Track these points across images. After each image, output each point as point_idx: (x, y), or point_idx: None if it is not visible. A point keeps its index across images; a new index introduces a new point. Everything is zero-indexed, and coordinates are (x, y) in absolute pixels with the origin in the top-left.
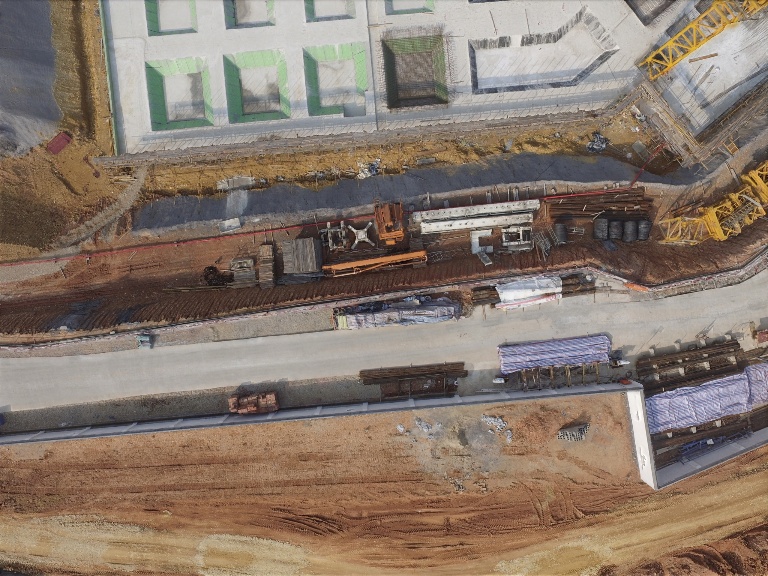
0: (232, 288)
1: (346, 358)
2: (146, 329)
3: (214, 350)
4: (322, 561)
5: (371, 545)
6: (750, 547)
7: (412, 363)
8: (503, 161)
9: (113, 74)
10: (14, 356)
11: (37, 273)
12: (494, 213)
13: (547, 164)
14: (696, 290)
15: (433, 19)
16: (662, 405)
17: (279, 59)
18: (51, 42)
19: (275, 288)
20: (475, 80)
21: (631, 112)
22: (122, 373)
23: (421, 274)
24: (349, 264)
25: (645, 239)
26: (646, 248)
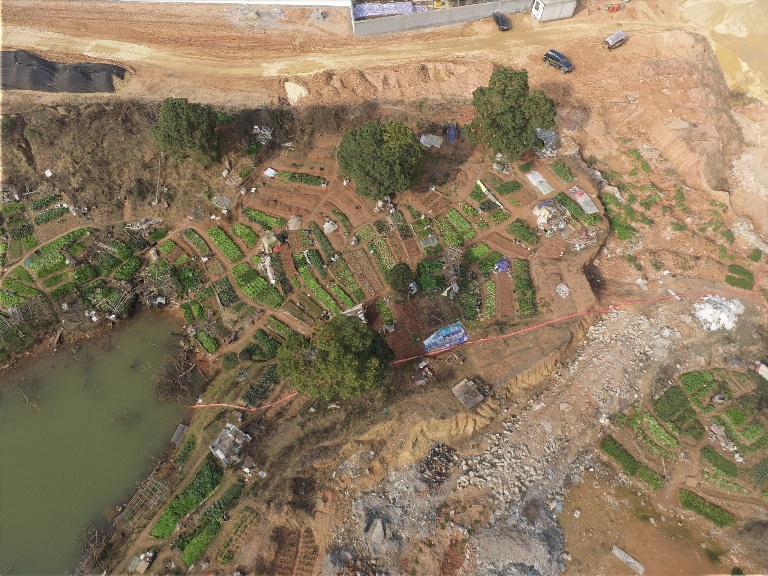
0: None
1: None
2: None
3: None
4: (159, 55)
5: None
6: None
7: None
8: None
9: None
10: None
11: None
12: None
13: None
14: None
15: None
16: (366, 8)
17: None
18: None
19: None
20: None
21: None
22: None
23: None
24: None
25: None
26: None
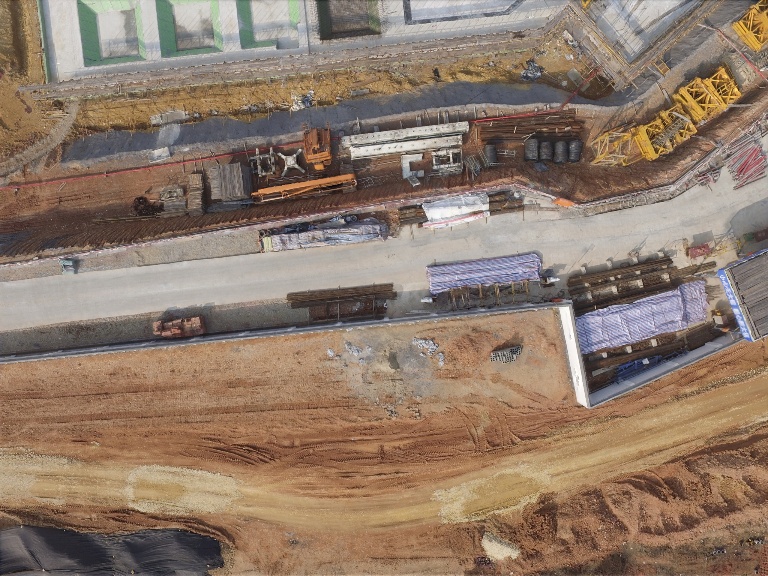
0: (162, 218)
1: (273, 281)
2: (70, 254)
3: (139, 275)
4: (254, 492)
5: (304, 474)
6: (691, 470)
7: (340, 285)
8: (436, 89)
9: (45, 11)
10: None
11: None
12: (424, 136)
13: (480, 91)
14: (627, 207)
15: None
16: (595, 324)
17: None
18: None
19: (204, 215)
20: (408, 11)
21: (564, 38)
22: (46, 299)
23: (349, 197)
24: (276, 188)
25: (577, 160)
26: (578, 169)
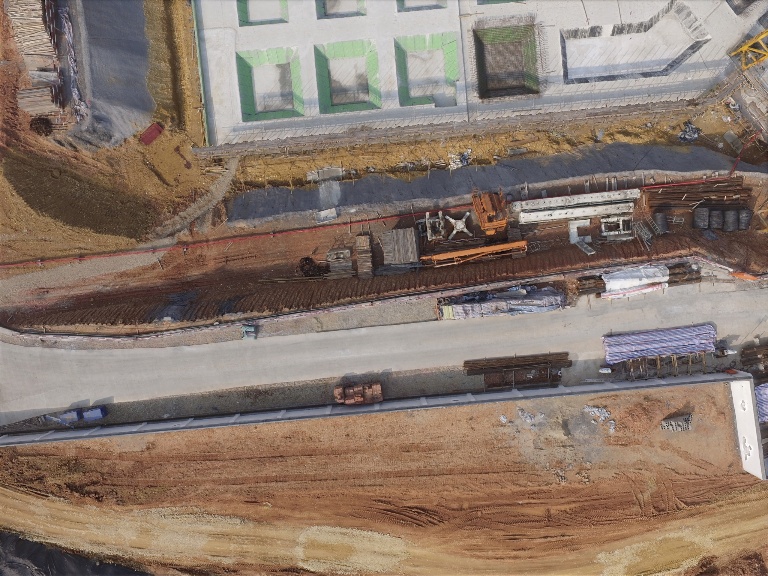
0: (329, 279)
1: (450, 348)
2: (250, 320)
3: (318, 341)
4: (422, 553)
5: (472, 536)
6: None
7: (516, 353)
8: (596, 151)
9: (204, 65)
10: (117, 347)
11: (135, 264)
12: (594, 203)
13: (642, 154)
14: None
15: (525, 9)
16: (767, 395)
17: (369, 49)
18: (144, 32)
19: (374, 279)
20: (565, 70)
21: (725, 101)
22: (226, 364)
23: (523, 264)
24: (451, 254)
25: (745, 228)
26: (746, 237)
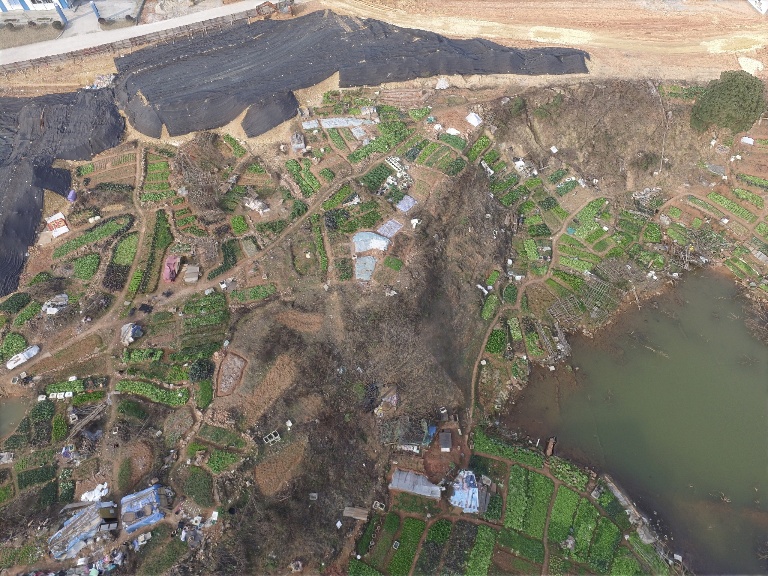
0: None
1: None
2: None
3: None
4: (600, 38)
5: (626, 32)
6: None
7: None
8: None
9: None
10: None
11: None
12: None
13: None
14: None
15: None
16: None
17: None
18: None
19: None
20: None
21: None
22: None
23: None
24: None
25: None
26: None
